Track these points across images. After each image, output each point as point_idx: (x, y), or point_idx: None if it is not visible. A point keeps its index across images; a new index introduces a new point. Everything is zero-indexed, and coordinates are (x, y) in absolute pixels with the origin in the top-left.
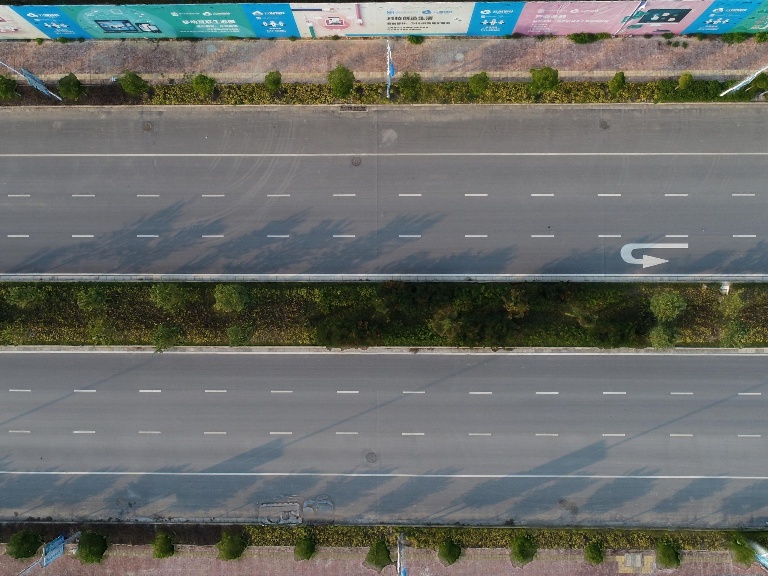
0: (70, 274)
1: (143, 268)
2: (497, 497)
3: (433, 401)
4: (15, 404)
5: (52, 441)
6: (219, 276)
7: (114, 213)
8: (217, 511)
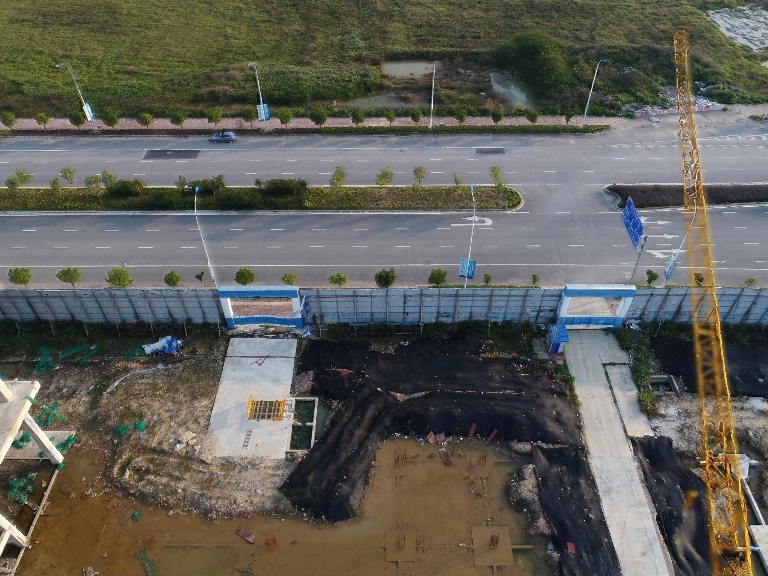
0: (47, 215)
1: (1, 217)
2: None
3: None
4: (108, 170)
5: (95, 159)
6: None
7: (4, 240)
8: (22, 140)
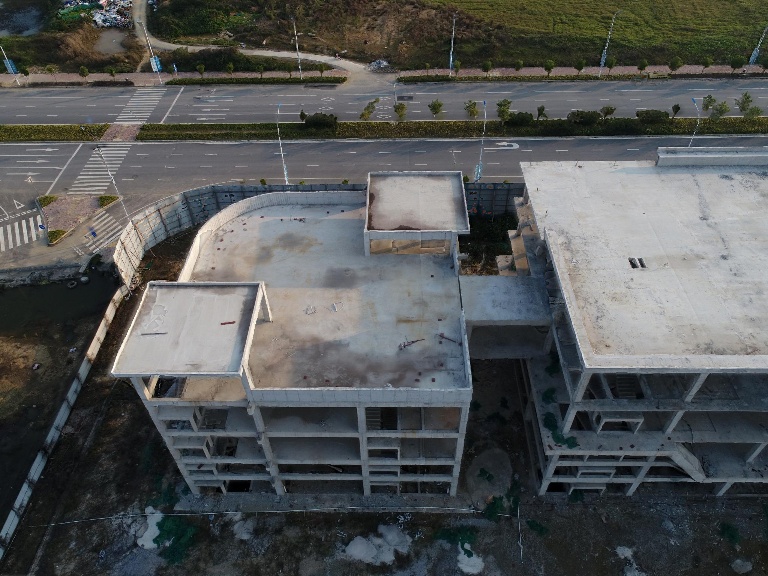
0: None
1: None
2: (558, 87)
3: (598, 107)
4: None
5: None
6: (729, 137)
7: None
8: (685, 82)
